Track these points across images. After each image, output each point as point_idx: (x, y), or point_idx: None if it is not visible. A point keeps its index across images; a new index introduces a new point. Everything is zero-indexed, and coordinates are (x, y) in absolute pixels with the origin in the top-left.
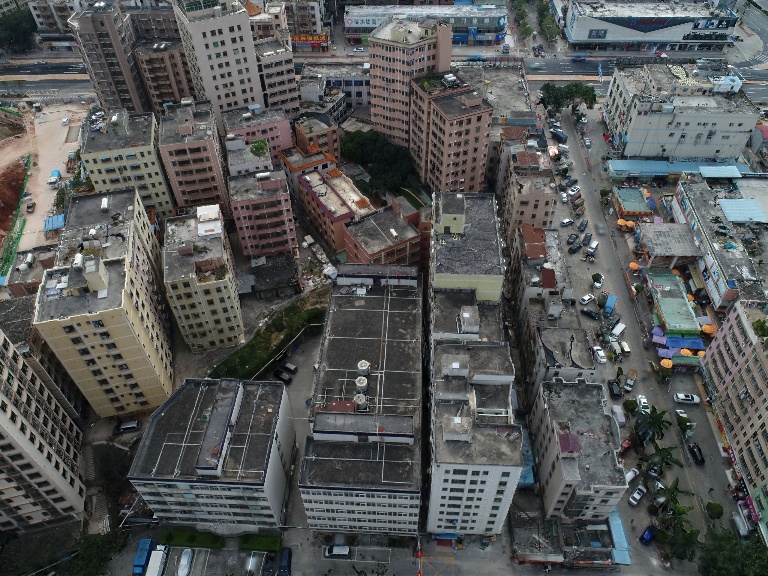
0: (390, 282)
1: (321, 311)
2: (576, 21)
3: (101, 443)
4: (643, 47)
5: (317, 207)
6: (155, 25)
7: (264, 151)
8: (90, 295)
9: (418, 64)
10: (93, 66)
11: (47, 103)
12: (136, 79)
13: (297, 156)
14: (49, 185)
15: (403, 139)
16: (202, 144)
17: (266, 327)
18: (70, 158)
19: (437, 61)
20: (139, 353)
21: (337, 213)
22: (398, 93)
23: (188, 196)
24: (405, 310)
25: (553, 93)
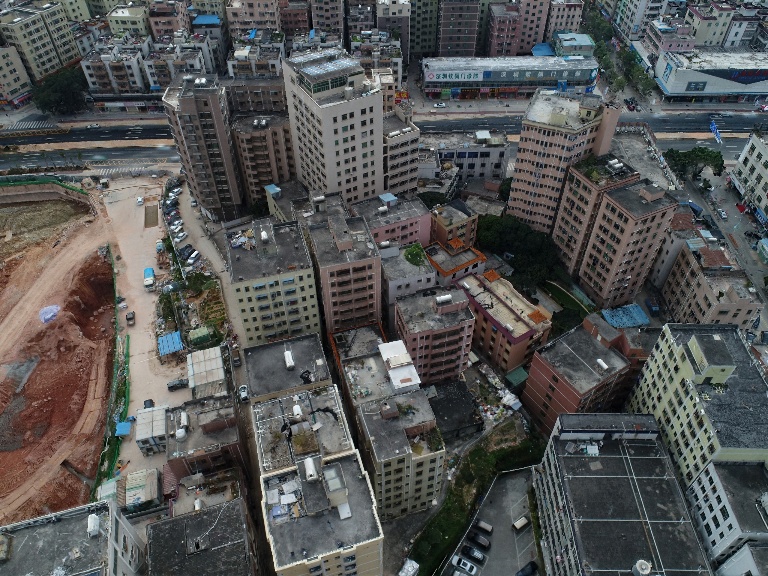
0: (625, 436)
1: (508, 452)
2: (674, 73)
3: None
4: (741, 99)
5: (483, 321)
6: (252, 97)
7: (422, 259)
8: (329, 513)
9: (578, 148)
10: (190, 148)
11: (113, 177)
12: (233, 159)
13: (442, 254)
14: (145, 288)
15: (545, 225)
16: (368, 262)
17: (456, 481)
18: (161, 251)
19: (597, 144)
20: (376, 572)
21: (515, 332)
22: (549, 178)
23: (340, 316)
24: (654, 475)
25: (681, 160)
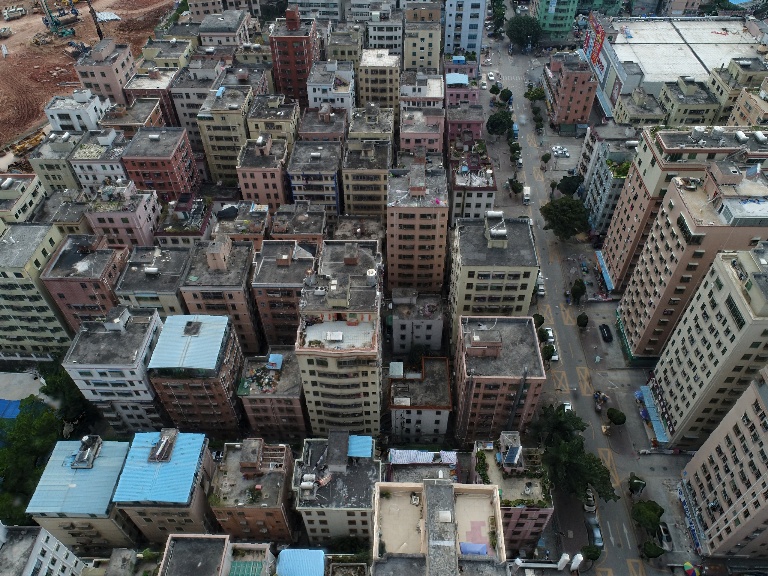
0: None
1: None
2: None
3: (263, 4)
4: None
5: None
6: None
7: None
8: None
9: None
10: None
11: None
12: None
13: None
14: None
15: None
16: None
17: None
18: None
19: None
20: None
21: None
22: None
23: None
24: None
25: None
